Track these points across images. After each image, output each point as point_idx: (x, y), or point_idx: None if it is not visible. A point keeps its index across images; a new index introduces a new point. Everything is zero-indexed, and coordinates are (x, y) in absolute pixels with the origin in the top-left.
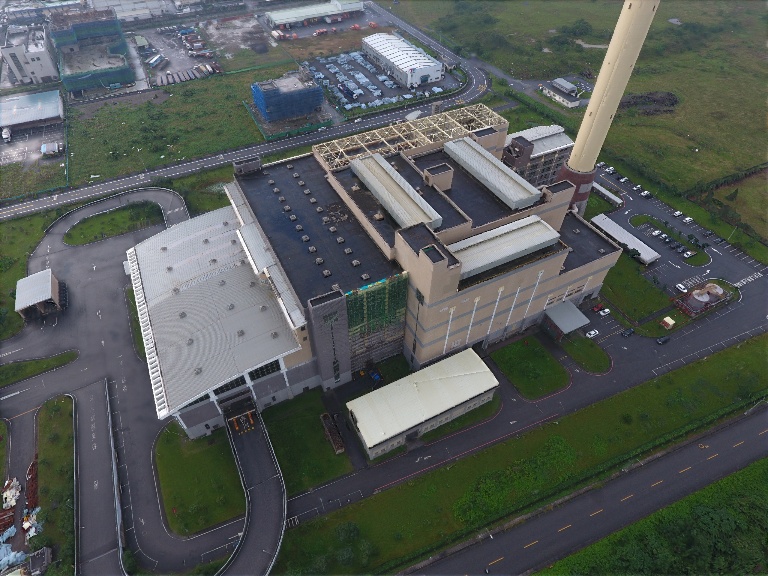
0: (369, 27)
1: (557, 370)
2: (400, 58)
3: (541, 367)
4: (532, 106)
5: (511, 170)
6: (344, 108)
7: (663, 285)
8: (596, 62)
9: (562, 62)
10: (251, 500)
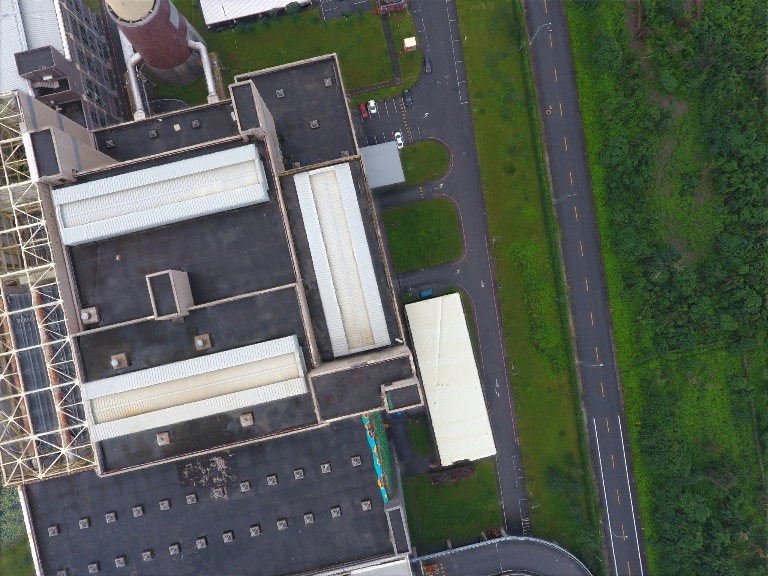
0: None
1: (435, 207)
2: None
3: (428, 224)
4: None
5: (180, 163)
6: None
7: (349, 6)
8: None
9: None
10: (512, 569)
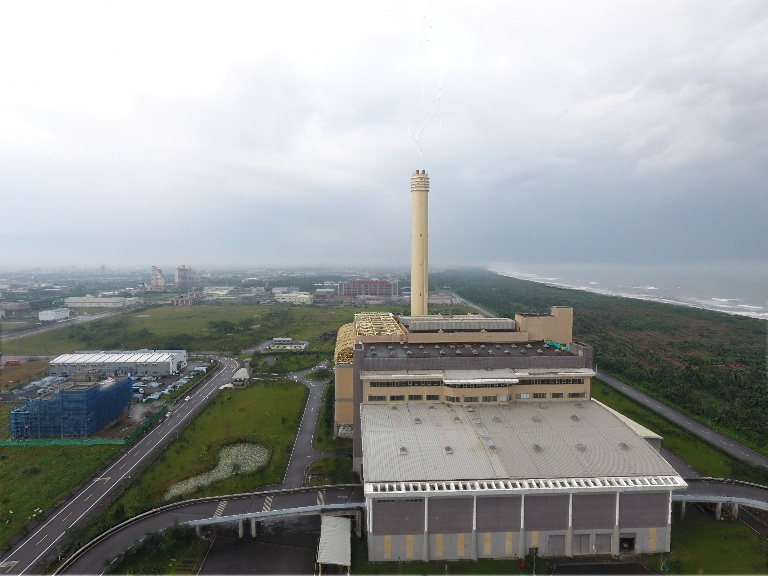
0: (7, 366)
1: None
2: (136, 358)
3: None
4: (290, 351)
5: None
6: (151, 399)
7: None
8: (266, 333)
9: (251, 336)
10: None
